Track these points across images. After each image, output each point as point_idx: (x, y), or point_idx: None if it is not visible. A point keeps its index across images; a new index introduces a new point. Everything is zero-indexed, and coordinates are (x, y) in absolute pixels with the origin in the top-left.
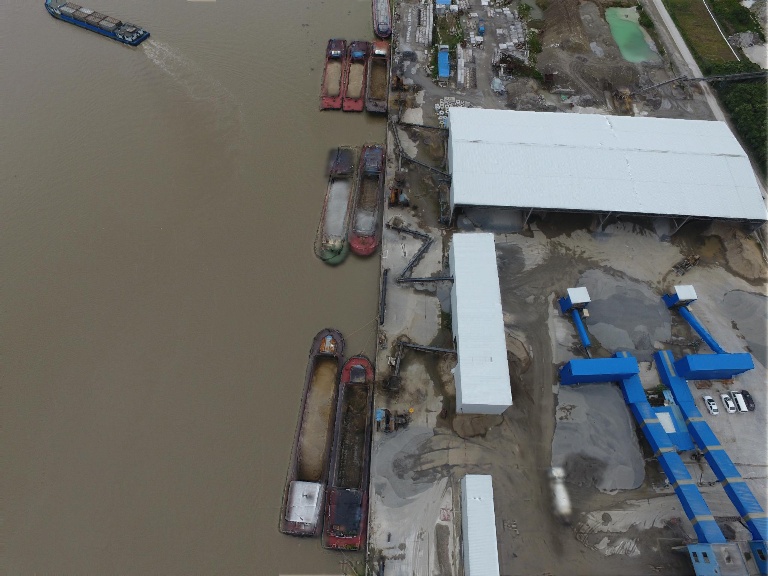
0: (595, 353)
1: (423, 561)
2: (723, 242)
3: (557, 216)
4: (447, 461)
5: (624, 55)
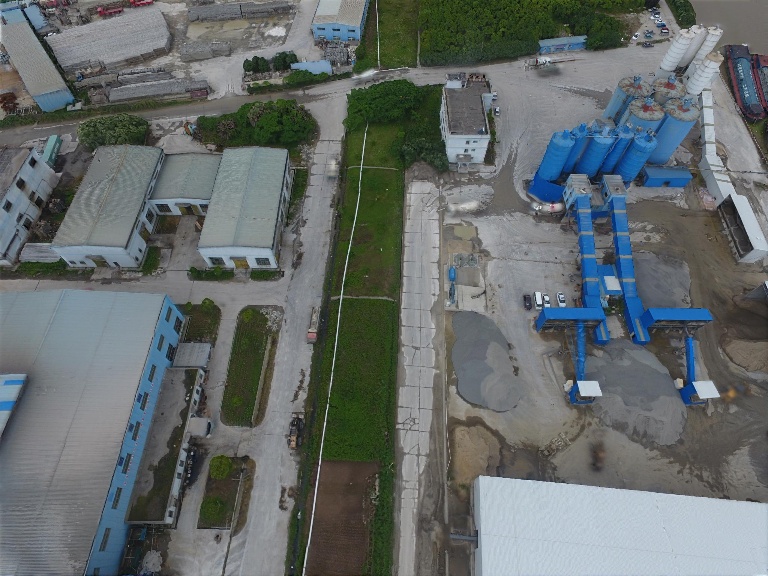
0: (661, 348)
1: (764, 226)
2: None
3: None
4: (767, 275)
5: None
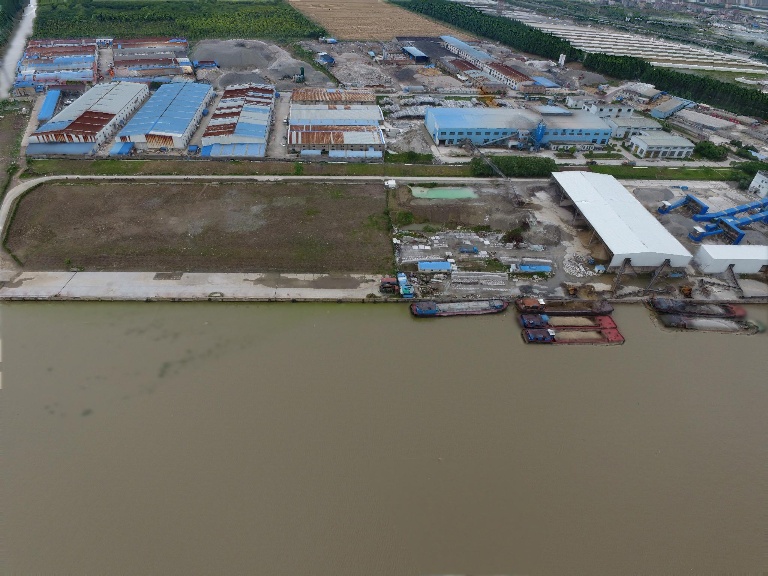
0: (711, 235)
1: None
2: None
3: None
4: None
5: None
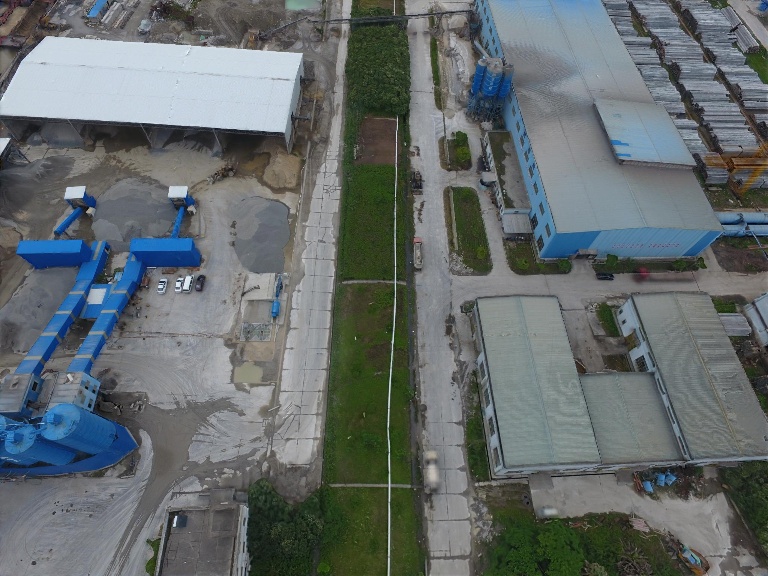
0: None
1: None
2: (270, 158)
3: (125, 134)
4: None
5: (288, 4)
